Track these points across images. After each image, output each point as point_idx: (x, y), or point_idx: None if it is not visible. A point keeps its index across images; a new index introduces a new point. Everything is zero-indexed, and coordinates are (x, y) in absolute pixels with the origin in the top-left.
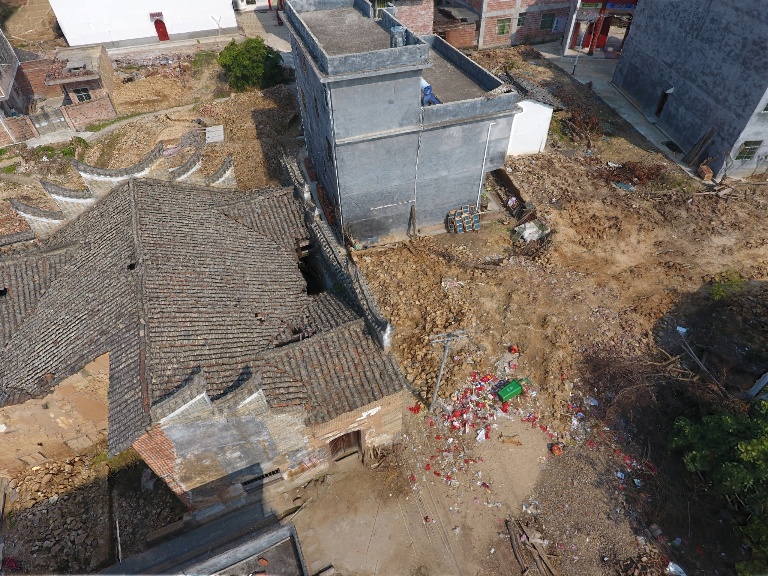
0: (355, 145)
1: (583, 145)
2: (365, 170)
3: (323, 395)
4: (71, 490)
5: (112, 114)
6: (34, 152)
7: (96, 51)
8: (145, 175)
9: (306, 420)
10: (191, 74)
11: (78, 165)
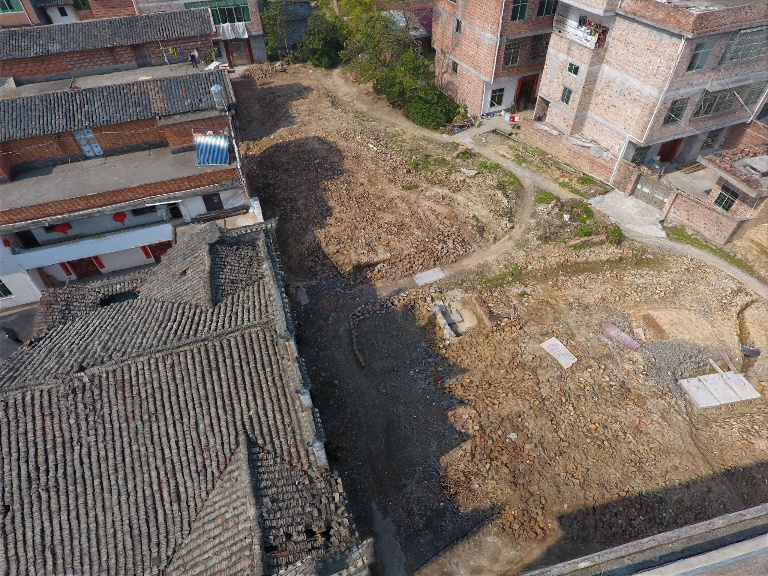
0: None
1: None
2: None
3: None
4: None
5: (720, 240)
6: (576, 204)
7: None
8: None
9: None
10: None
11: (266, 260)
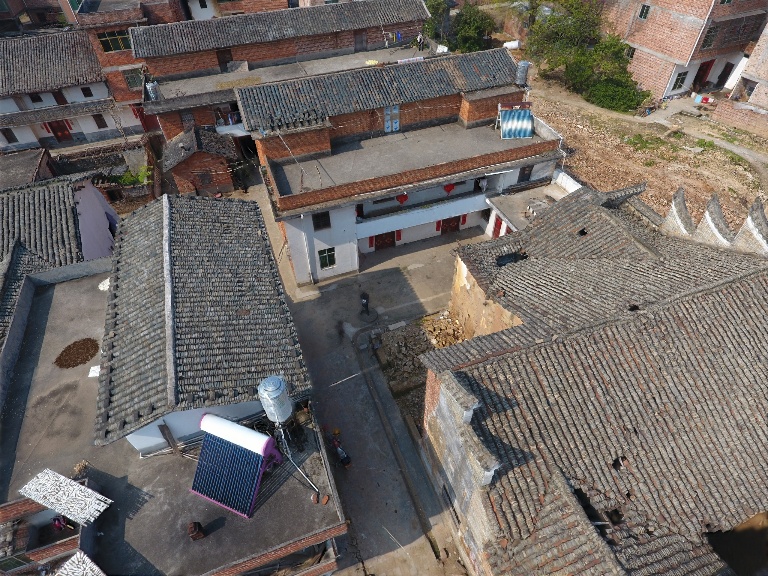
0: None
1: None
2: None
3: (524, 563)
4: None
5: None
6: None
7: None
8: None
9: (491, 542)
10: None
11: (756, 210)
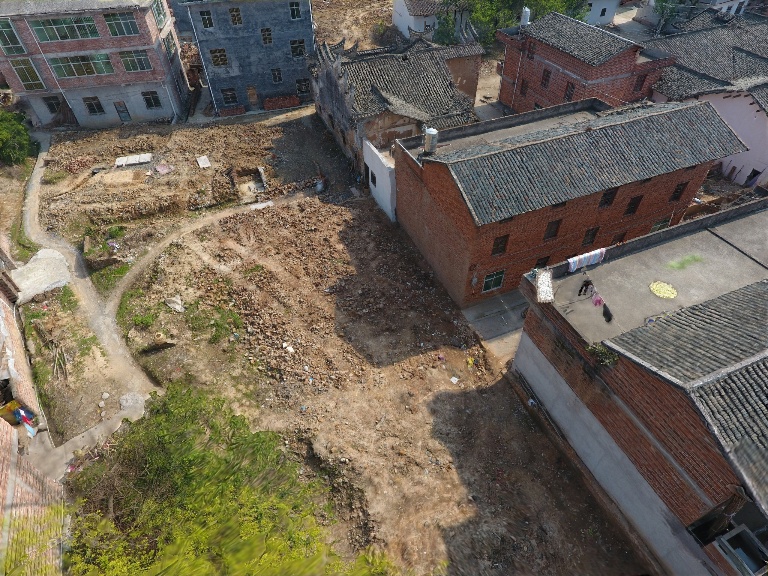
0: None
1: None
2: None
3: None
4: None
5: None
6: None
7: None
8: None
9: None
10: None
11: None
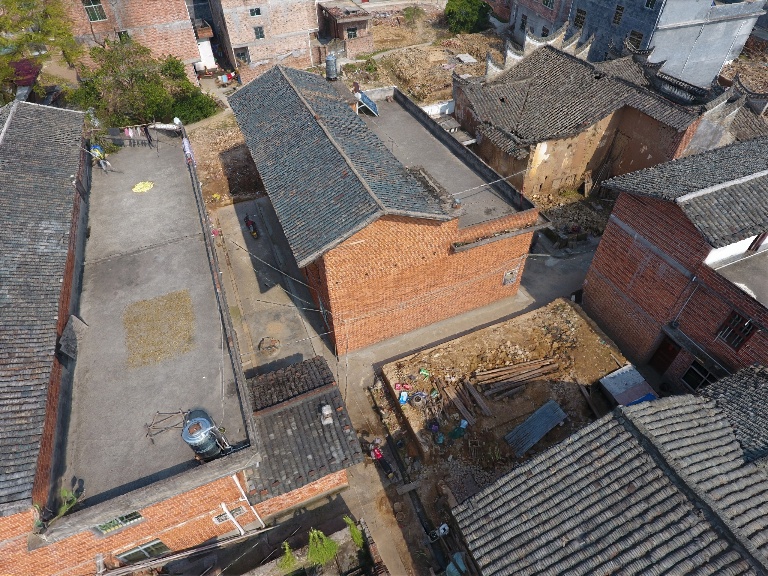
0: (665, 31)
1: (760, 60)
2: (662, 51)
3: None
4: (564, 204)
5: (371, 48)
6: (345, 68)
7: (350, 2)
8: (552, 43)
9: None
10: (406, 24)
11: None
